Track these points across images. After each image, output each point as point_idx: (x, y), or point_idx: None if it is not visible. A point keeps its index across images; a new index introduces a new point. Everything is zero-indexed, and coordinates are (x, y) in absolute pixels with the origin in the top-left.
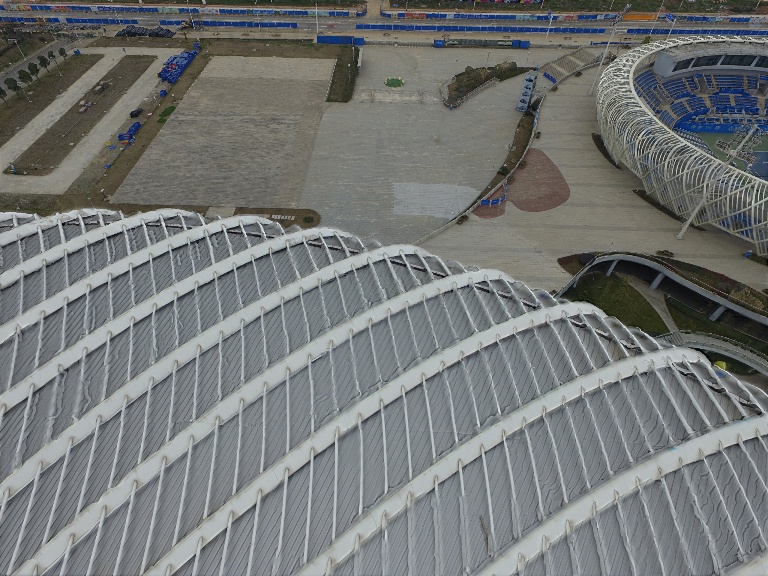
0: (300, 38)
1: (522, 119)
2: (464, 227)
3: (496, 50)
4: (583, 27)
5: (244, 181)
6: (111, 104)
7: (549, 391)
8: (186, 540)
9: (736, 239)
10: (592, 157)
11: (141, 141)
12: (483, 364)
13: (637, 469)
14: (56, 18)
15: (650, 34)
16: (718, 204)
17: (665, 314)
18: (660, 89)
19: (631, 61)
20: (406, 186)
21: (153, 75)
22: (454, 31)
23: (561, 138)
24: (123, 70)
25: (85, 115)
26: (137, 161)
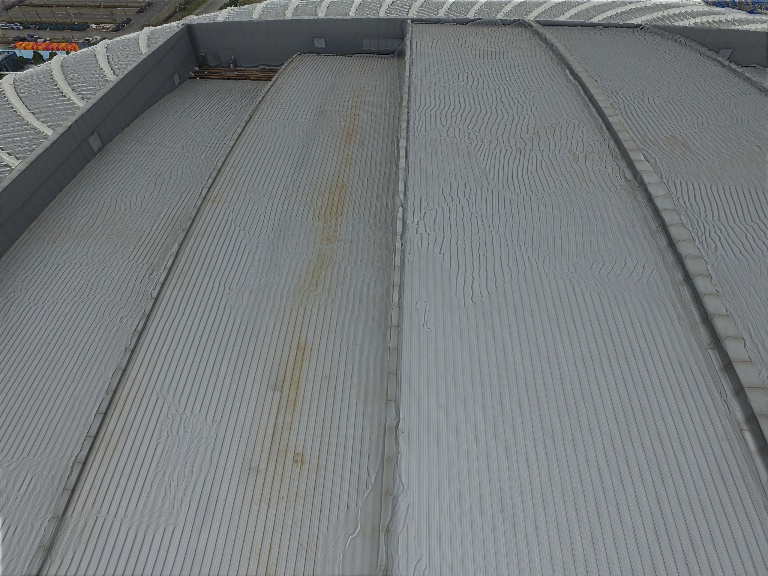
0: None
1: None
2: None
3: None
4: None
5: None
6: None
7: (704, 5)
8: (609, 12)
9: None
10: None
11: None
12: (676, 3)
13: (740, 14)
14: None
15: None
16: None
17: None
18: None
19: None
20: None
21: None
22: None
23: None
24: None
25: None
26: None
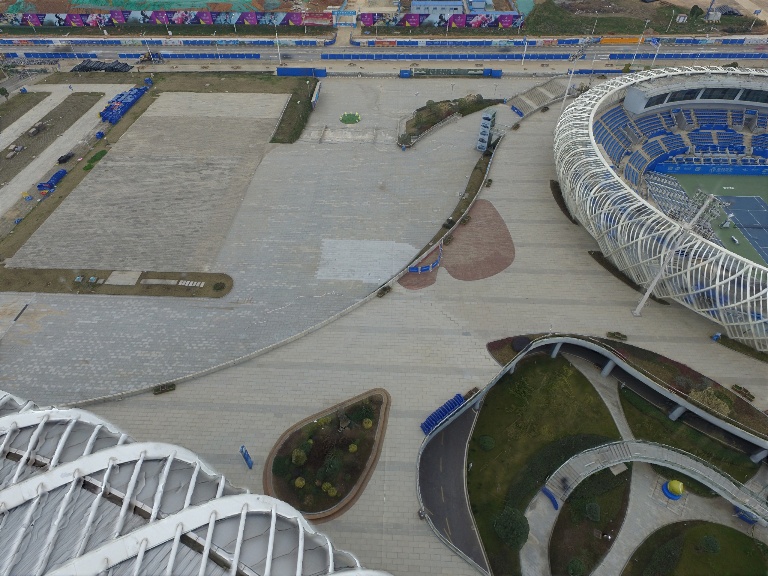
0: (261, 70)
1: (480, 160)
2: (384, 301)
3: (466, 80)
4: (563, 52)
5: (159, 239)
6: (42, 148)
7: None
8: None
9: (703, 318)
10: (547, 210)
11: (60, 192)
12: None
13: None
14: (14, 53)
15: (634, 59)
16: (678, 279)
17: (617, 410)
18: (631, 127)
19: (595, 99)
20: (337, 243)
21: (95, 114)
22: (424, 59)
23: (515, 186)
24: (66, 109)
25: (11, 161)
26: (49, 216)
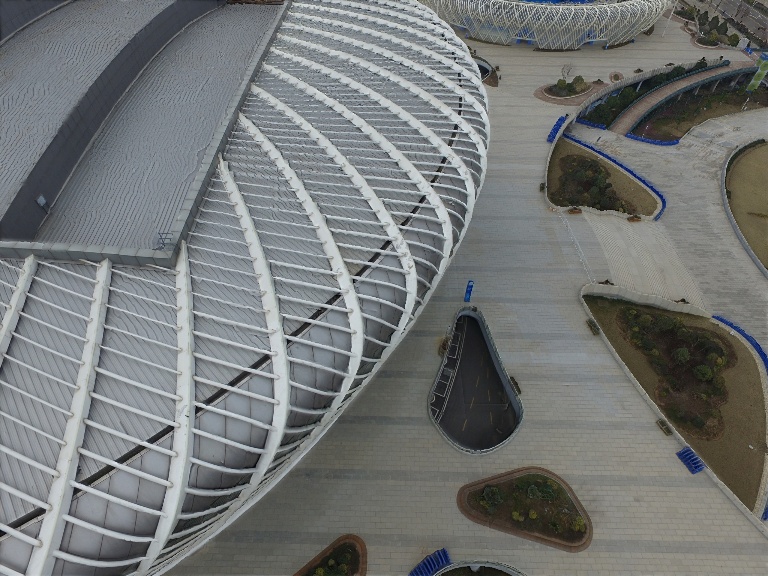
0: None
1: None
2: None
3: None
4: None
5: None
6: None
7: None
8: None
9: (463, 30)
10: None
11: None
12: None
13: None
14: None
15: None
16: (447, 7)
17: None
18: None
19: None
20: None
21: None
22: None
23: None
24: None
25: None
26: None
